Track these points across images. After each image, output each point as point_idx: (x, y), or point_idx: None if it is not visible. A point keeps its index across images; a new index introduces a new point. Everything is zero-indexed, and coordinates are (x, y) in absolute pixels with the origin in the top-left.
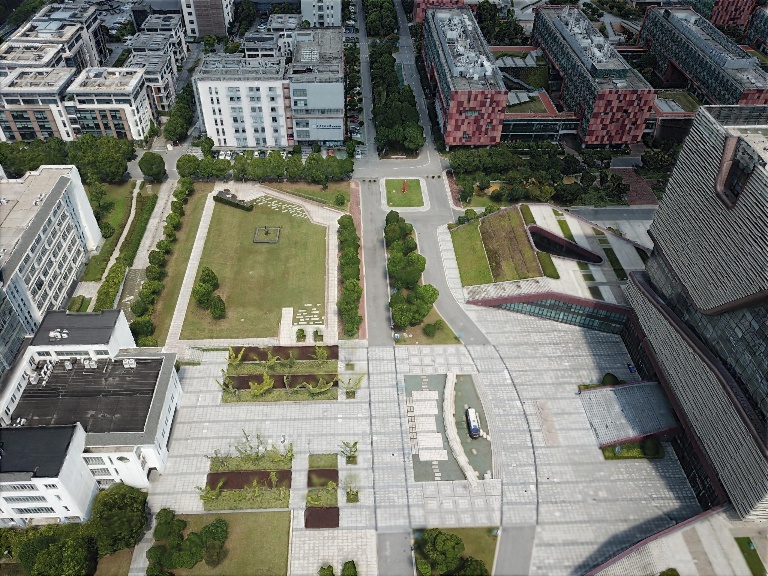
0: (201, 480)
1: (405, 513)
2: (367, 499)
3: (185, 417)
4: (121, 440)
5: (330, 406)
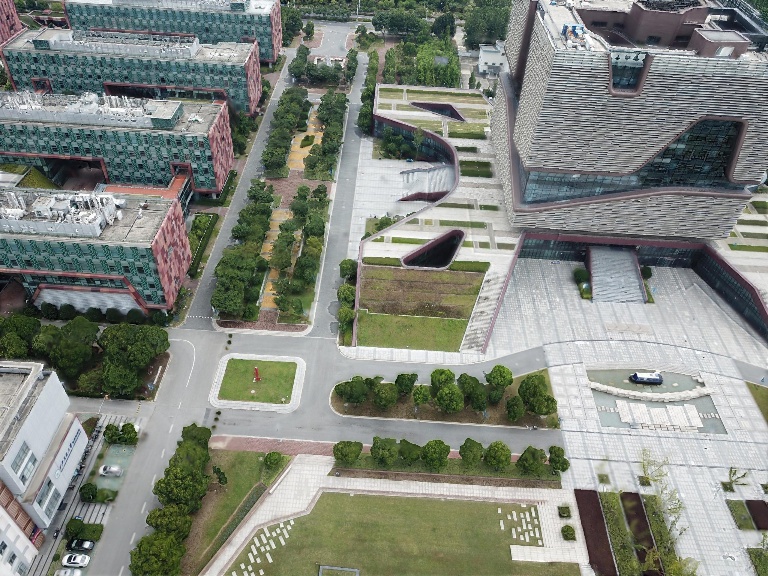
0: None
1: (764, 446)
2: (764, 476)
3: None
4: None
5: None
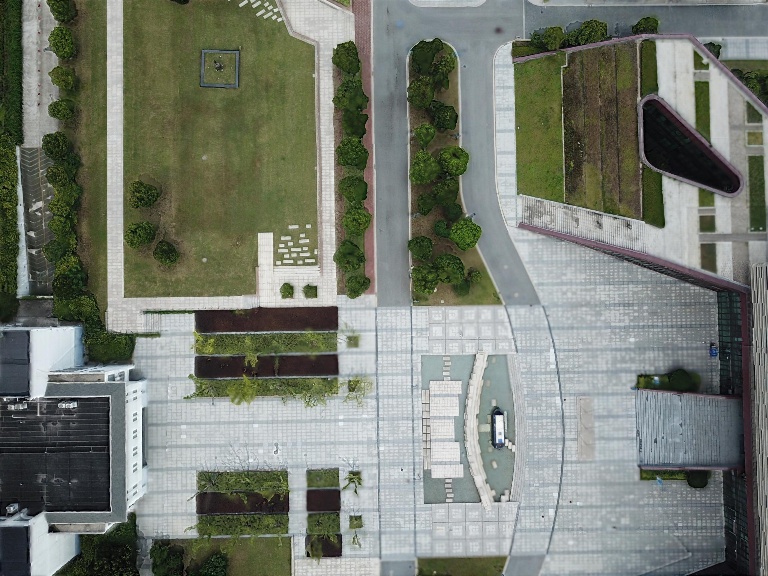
0: (190, 500)
1: (411, 540)
2: (371, 524)
3: (156, 417)
4: (87, 519)
5: (329, 403)
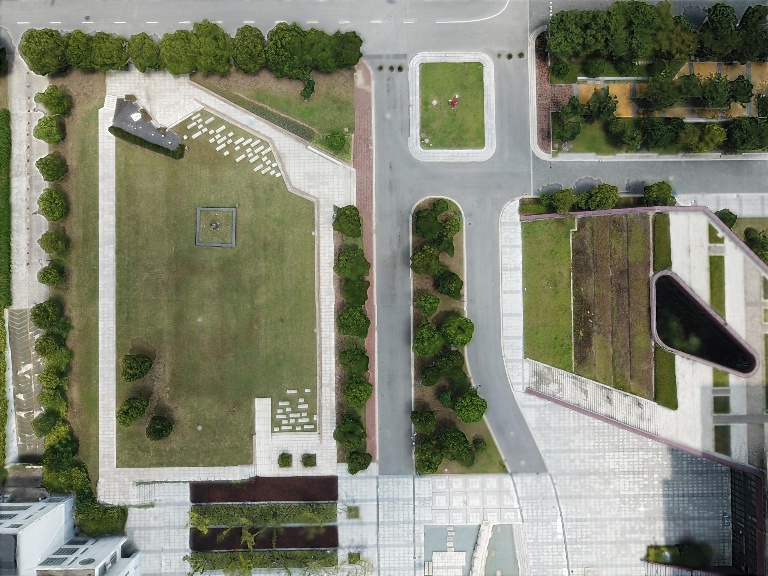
0: None
1: None
2: None
3: None
4: None
5: None
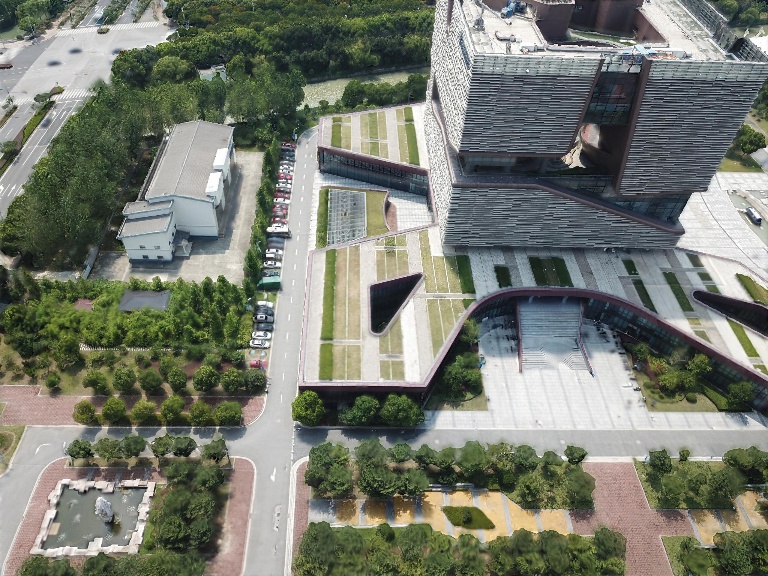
0: None
1: None
2: None
3: None
4: None
5: None
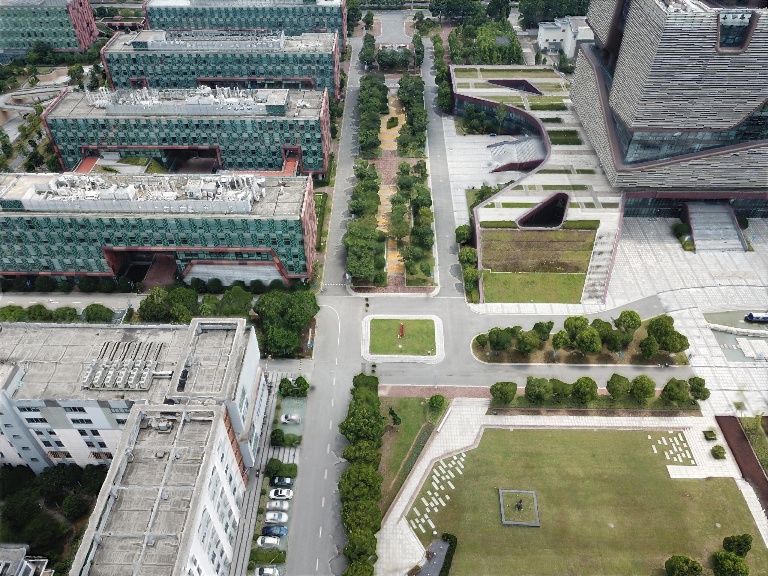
0: None
1: None
2: None
3: None
4: None
5: None
